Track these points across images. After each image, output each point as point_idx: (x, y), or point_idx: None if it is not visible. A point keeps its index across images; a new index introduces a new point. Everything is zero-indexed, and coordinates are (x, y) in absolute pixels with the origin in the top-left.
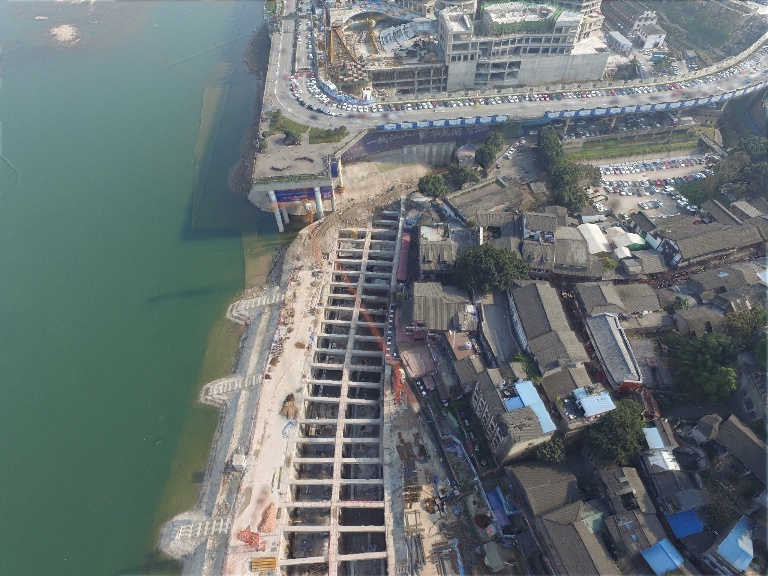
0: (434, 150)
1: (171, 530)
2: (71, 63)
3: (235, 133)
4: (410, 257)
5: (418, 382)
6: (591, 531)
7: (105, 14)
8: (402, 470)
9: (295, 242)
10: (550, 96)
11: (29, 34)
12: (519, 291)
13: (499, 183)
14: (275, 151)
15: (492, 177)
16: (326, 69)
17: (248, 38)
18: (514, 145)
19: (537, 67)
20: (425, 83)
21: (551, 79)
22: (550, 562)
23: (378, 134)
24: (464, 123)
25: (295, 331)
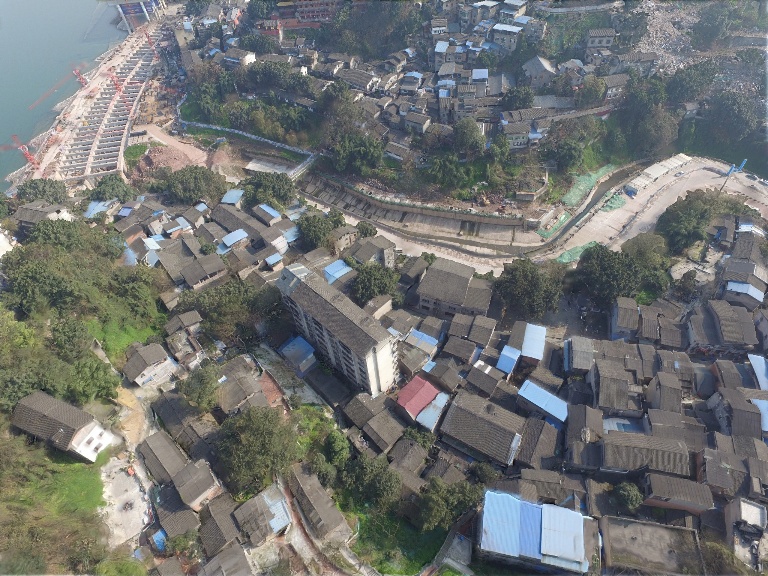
0: None
1: None
2: None
3: None
4: None
5: None
6: None
7: None
8: None
9: None
10: None
11: None
12: (204, 7)
13: None
14: None
15: None
16: None
17: None
18: None
19: None
20: None
21: None
22: None
23: None
24: None
25: (122, 53)
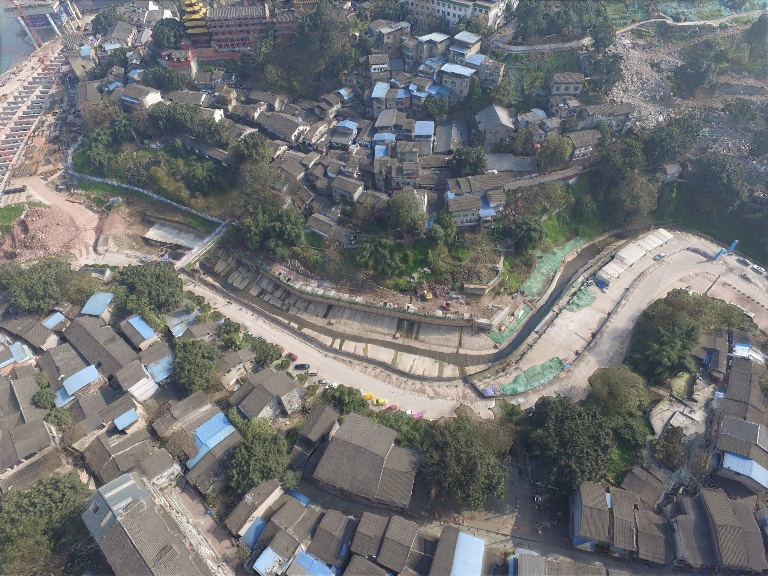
0: None
1: None
2: None
3: None
4: None
5: (67, 77)
6: None
7: None
8: None
9: None
10: None
11: None
12: None
13: None
14: None
15: None
16: None
17: None
18: None
19: None
20: None
21: None
22: None
23: None
24: None
25: (19, 76)
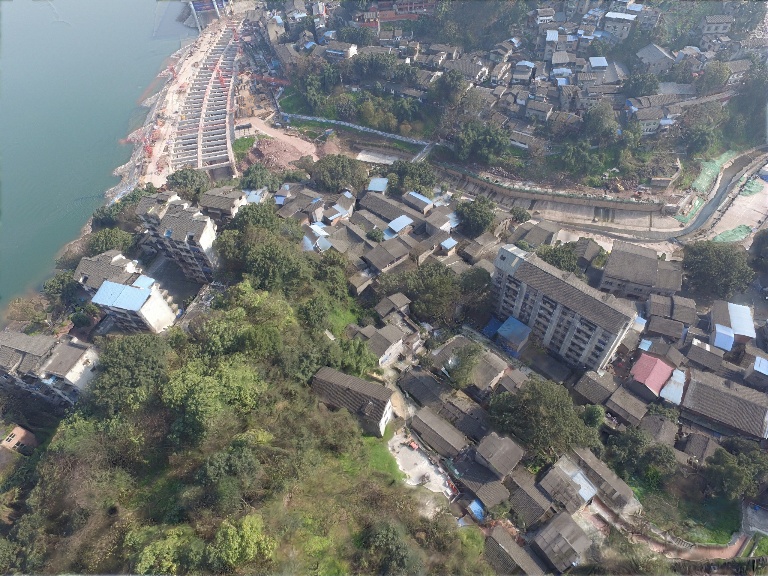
0: None
1: None
2: None
3: (178, 5)
4: None
5: None
6: (292, 47)
7: None
8: None
9: None
10: None
11: None
12: (287, 2)
13: None
14: None
15: None
16: None
17: None
18: None
19: None
20: None
21: None
22: None
23: None
24: None
25: (201, 49)
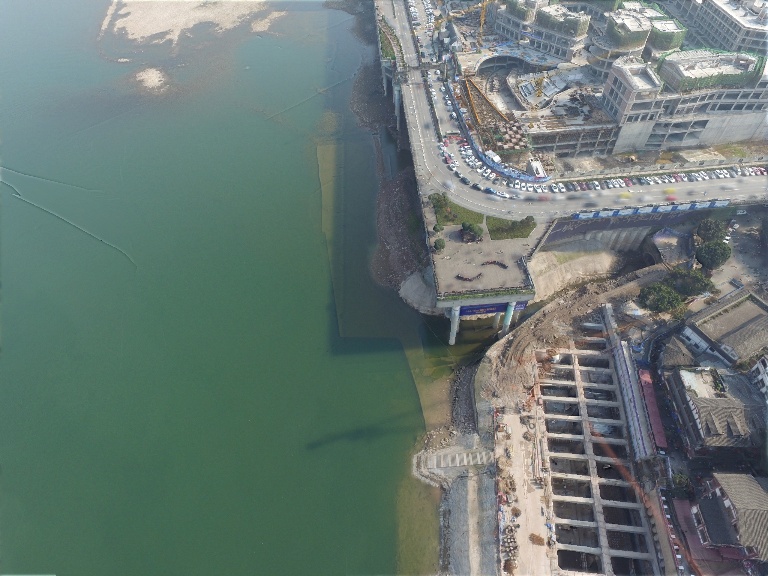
0: (623, 236)
1: None
2: (164, 114)
3: (364, 204)
4: (660, 408)
5: None
6: None
7: (191, 55)
8: None
9: (483, 367)
10: (767, 169)
11: (114, 80)
12: None
13: (755, 301)
14: (453, 251)
15: (715, 278)
16: (479, 133)
17: (351, 82)
18: (727, 231)
19: (725, 126)
20: (588, 145)
21: (737, 138)
22: None
23: (566, 222)
24: (675, 209)
25: (523, 514)
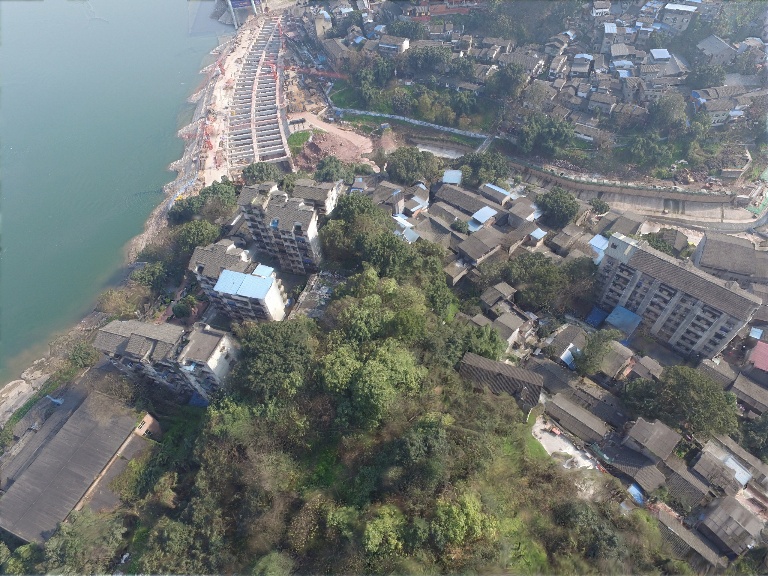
0: None
1: (191, 96)
2: None
3: (210, 2)
4: None
5: (292, 41)
6: None
7: None
8: (284, 65)
9: None
10: None
11: None
12: None
13: None
14: None
15: None
16: None
17: None
18: None
19: None
20: None
21: None
22: (328, 57)
23: None
24: None
25: (242, 45)
